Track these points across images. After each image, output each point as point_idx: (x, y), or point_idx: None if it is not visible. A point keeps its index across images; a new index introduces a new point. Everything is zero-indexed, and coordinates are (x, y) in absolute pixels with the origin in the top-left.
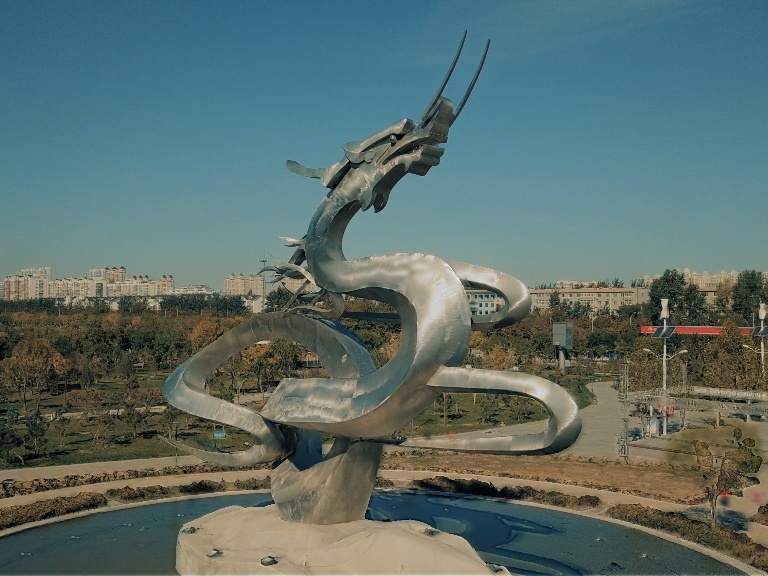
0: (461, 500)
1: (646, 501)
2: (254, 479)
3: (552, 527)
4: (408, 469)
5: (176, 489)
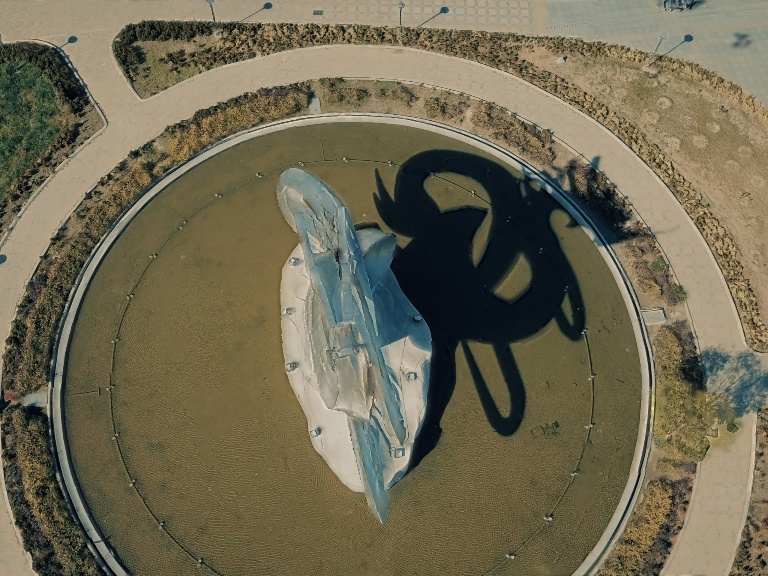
0: (577, 228)
1: (729, 318)
2: (447, 92)
3: (584, 334)
4: (602, 119)
5: (377, 87)
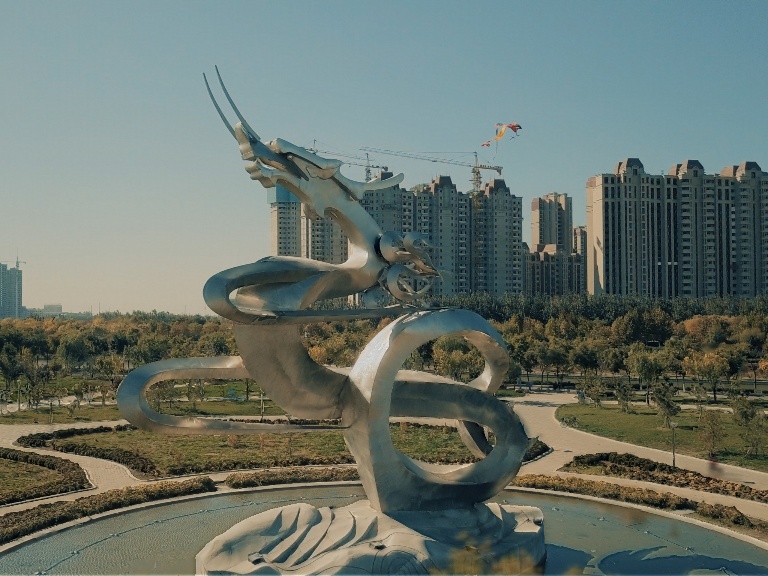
0: None
1: None
2: None
3: None
4: None
5: None
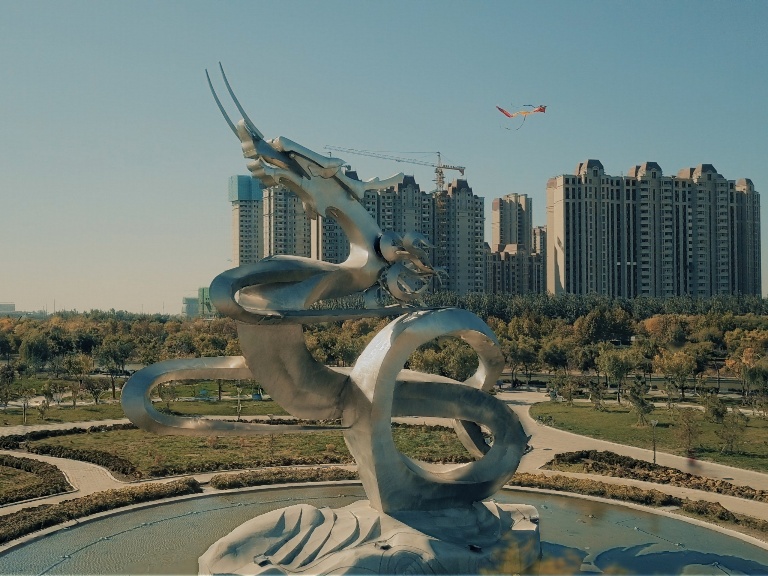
0: None
1: None
2: None
3: None
4: None
5: None
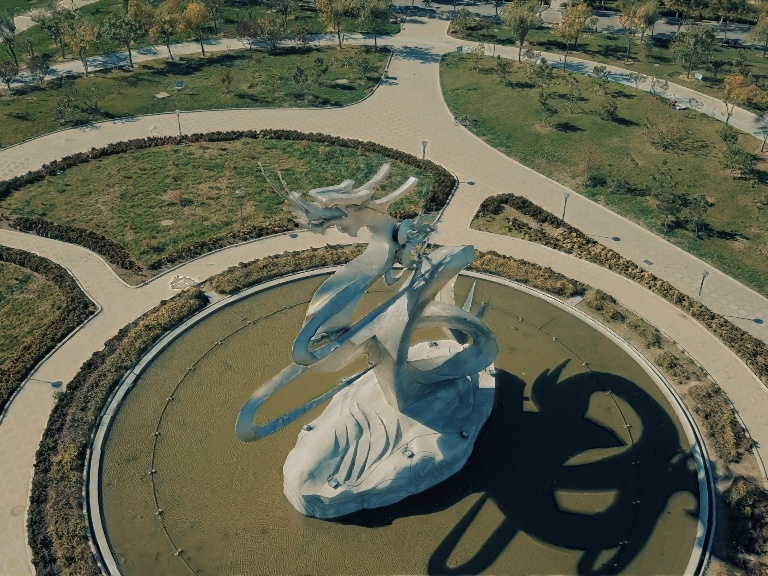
0: (694, 518)
1: None
2: (691, 360)
3: None
4: None
5: (637, 322)
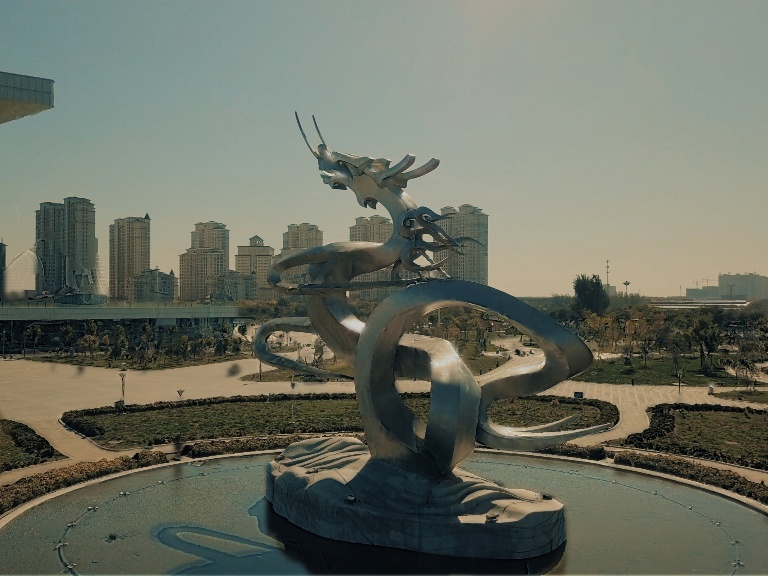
0: None
1: None
2: None
3: None
4: None
5: None
